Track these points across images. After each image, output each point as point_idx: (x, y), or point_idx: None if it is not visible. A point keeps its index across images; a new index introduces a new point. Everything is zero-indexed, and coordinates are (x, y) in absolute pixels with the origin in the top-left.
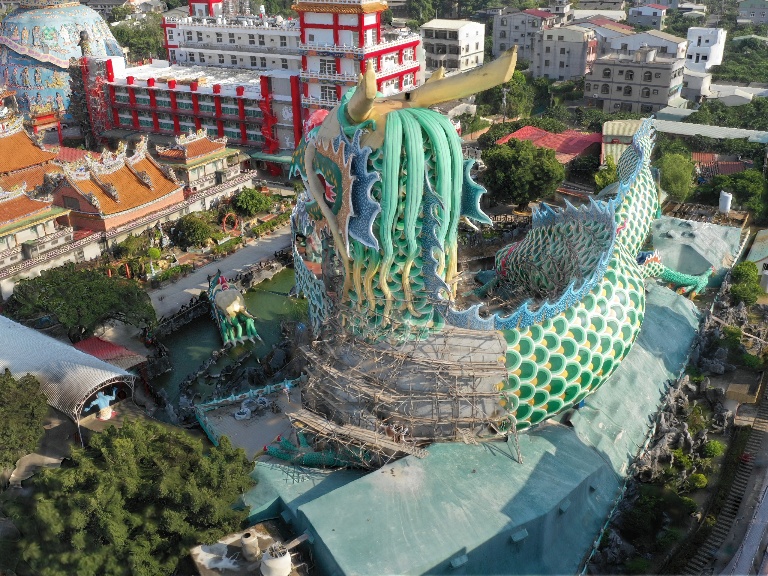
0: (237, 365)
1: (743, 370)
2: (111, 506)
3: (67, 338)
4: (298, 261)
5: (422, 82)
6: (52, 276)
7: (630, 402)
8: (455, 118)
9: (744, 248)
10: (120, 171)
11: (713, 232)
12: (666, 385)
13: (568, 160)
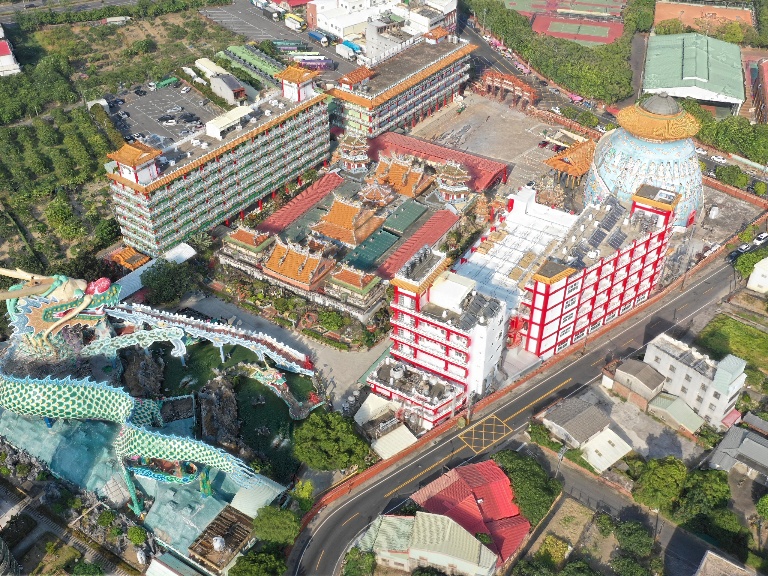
0: (158, 342)
1: (41, 493)
2: (5, 304)
3: (194, 290)
4: (131, 323)
5: (719, 410)
6: (165, 264)
7: (26, 437)
8: (532, 424)
9: (198, 567)
10: (303, 256)
11: (185, 527)
12: (44, 461)
13: (415, 499)
